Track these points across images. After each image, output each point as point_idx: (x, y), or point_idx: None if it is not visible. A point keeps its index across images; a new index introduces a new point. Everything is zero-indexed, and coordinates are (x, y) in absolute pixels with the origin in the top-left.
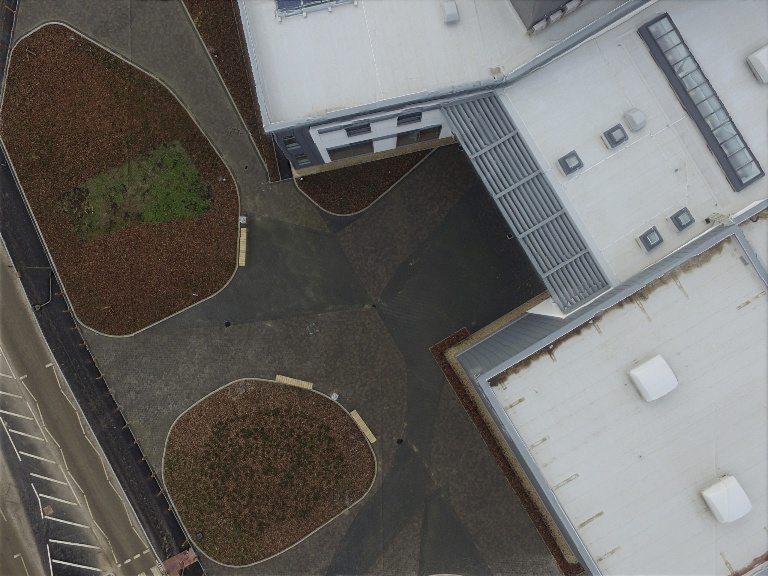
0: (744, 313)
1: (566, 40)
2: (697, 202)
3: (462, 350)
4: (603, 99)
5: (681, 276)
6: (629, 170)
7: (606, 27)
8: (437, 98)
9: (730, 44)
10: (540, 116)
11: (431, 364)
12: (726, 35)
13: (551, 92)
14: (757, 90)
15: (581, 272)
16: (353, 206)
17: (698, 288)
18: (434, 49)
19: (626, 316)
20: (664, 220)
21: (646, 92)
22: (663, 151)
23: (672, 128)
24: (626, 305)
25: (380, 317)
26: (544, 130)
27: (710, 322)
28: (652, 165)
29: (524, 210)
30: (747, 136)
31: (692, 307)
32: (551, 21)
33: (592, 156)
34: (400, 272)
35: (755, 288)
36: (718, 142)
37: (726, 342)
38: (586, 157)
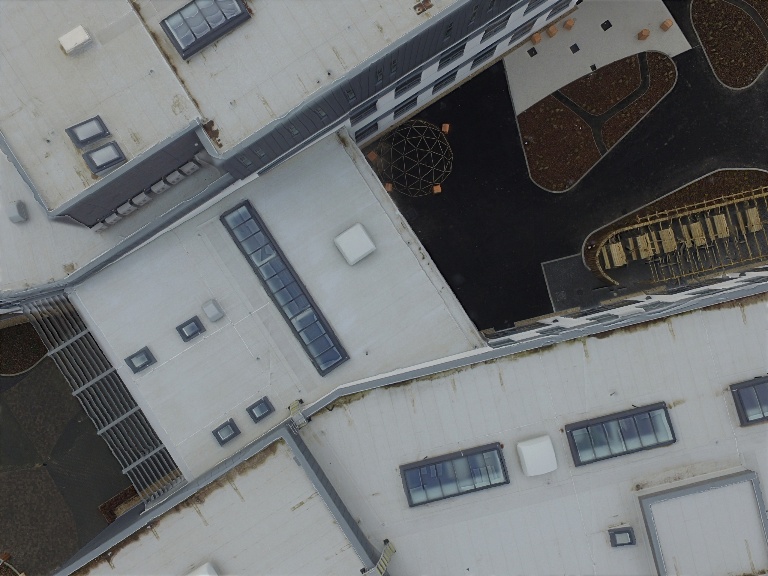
0: (298, 514)
1: (120, 243)
2: (280, 389)
3: (130, 508)
4: (182, 290)
5: (236, 478)
6: (208, 361)
7: (175, 222)
8: (11, 296)
9: (320, 225)
10: (113, 312)
11: (101, 522)
12: (316, 216)
13: (125, 287)
14: (347, 270)
15: (164, 465)
16: (18, 366)
17: (253, 490)
18: (6, 248)
19: (183, 520)
20: (245, 410)
21: (226, 281)
22: (245, 339)
23: (255, 315)
24: (183, 509)
25: (51, 476)
26: (117, 326)
27: (265, 524)
28: (233, 354)
29: (103, 406)
30: (336, 318)
31: (247, 509)
32: (109, 223)
33: (168, 350)
34: (69, 430)
35: (308, 489)
36: (296, 330)
37: (281, 544)
38: (162, 351)
